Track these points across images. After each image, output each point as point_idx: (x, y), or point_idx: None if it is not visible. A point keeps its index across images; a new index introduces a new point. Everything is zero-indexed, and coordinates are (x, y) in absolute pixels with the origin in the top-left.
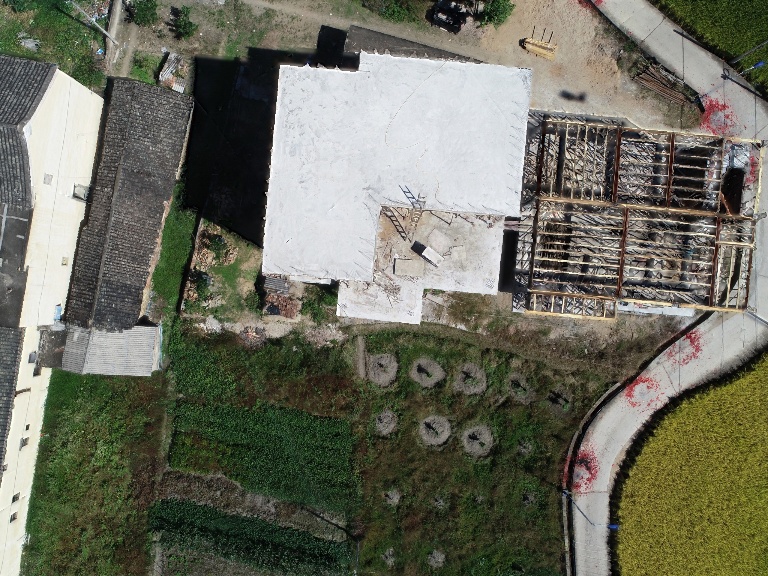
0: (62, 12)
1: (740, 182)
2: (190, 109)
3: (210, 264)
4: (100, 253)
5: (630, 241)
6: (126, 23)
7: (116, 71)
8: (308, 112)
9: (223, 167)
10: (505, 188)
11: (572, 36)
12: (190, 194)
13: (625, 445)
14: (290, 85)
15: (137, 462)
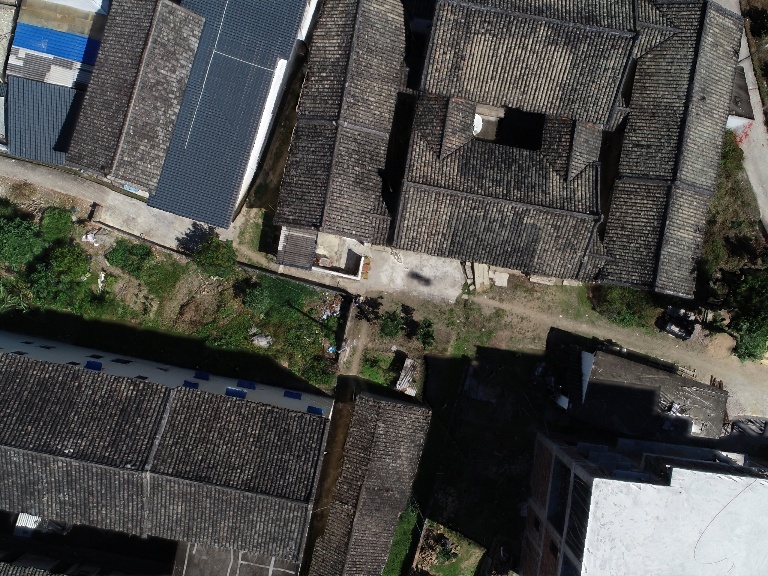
0: (294, 308)
1: None
2: (428, 422)
3: (432, 562)
4: (339, 571)
5: None
6: (357, 320)
7: (346, 369)
8: (620, 526)
9: (448, 466)
10: None
11: None
12: (416, 494)
13: None
14: (603, 499)
15: None
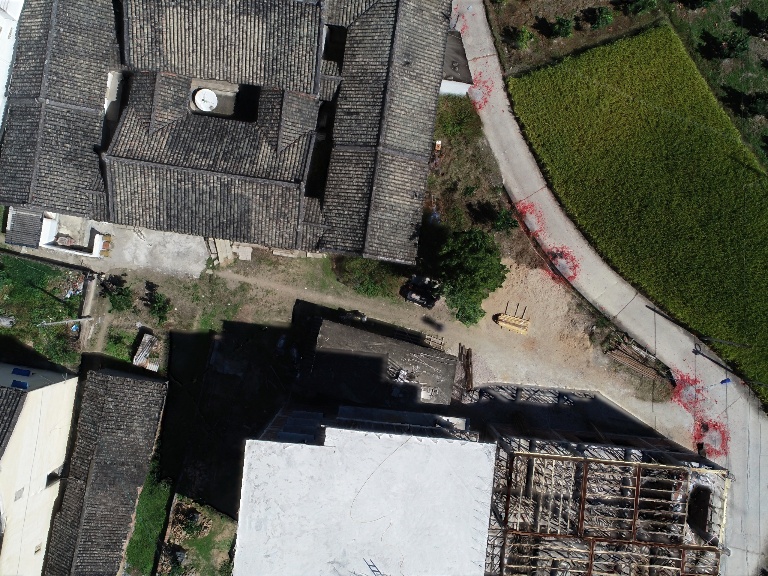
0: (37, 288)
1: (706, 499)
2: (164, 396)
3: (184, 537)
4: (73, 545)
5: (596, 574)
6: (101, 297)
7: (91, 347)
8: (274, 487)
9: (197, 440)
10: (469, 561)
11: (545, 311)
12: (164, 469)
13: None
14: (256, 460)
15: None
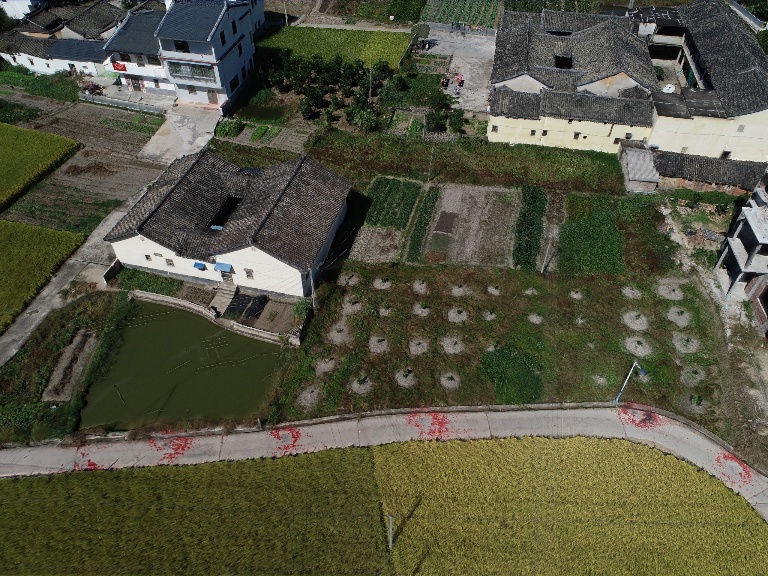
0: None
1: None
2: None
3: None
4: None
5: None
6: None
7: None
8: None
9: None
10: None
11: None
12: None
13: (676, 453)
14: None
15: (566, 183)
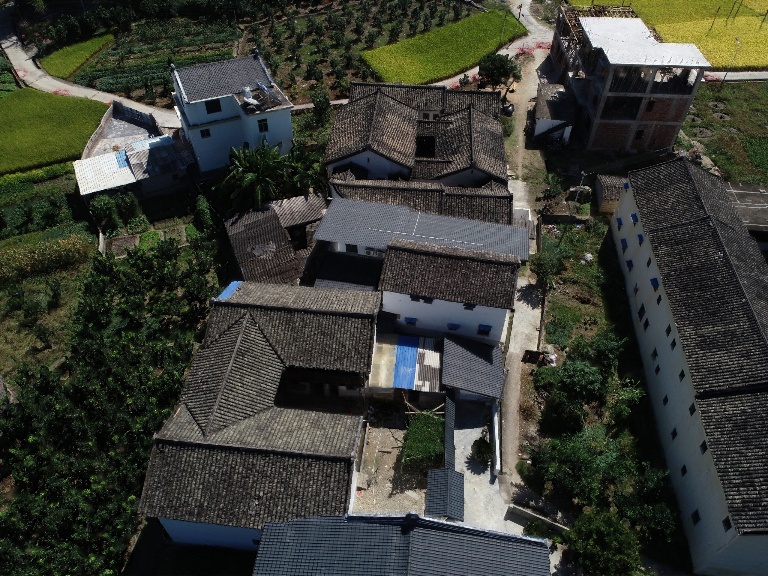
0: None
1: None
2: None
3: None
4: None
5: None
6: None
7: None
8: None
9: None
10: None
11: None
12: None
13: None
14: None
15: None
